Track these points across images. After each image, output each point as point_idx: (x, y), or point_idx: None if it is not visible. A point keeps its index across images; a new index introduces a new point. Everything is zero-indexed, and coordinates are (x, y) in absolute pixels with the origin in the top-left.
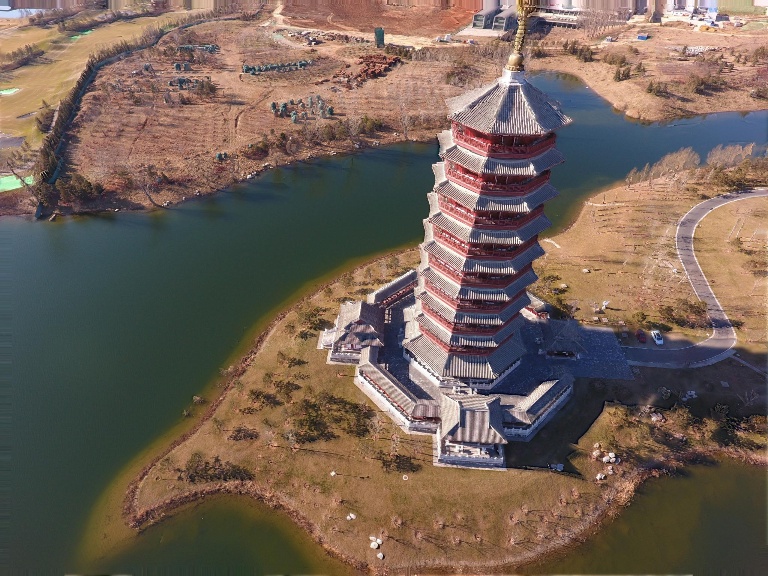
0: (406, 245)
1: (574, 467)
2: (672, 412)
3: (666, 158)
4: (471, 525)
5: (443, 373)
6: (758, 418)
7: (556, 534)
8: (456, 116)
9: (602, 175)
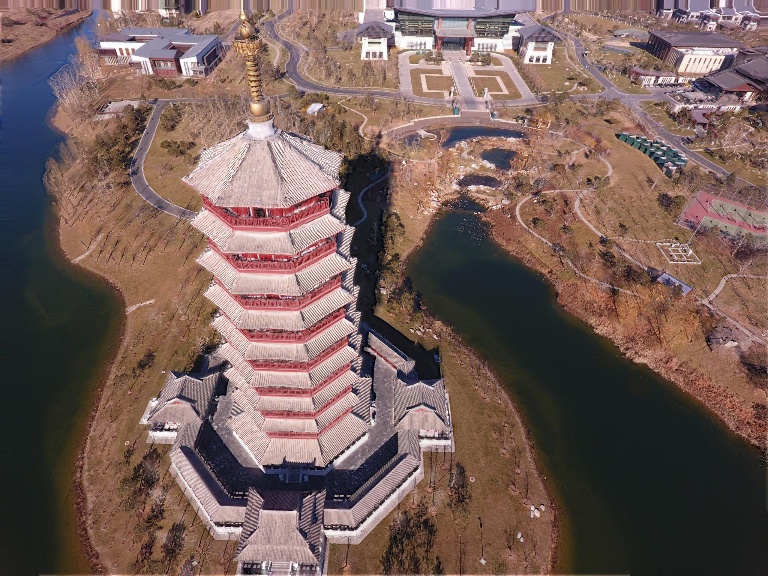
0: (59, 480)
1: (434, 349)
2: (386, 279)
3: (52, 179)
4: (498, 428)
5: (368, 423)
6: (391, 241)
7: (485, 374)
8: (291, 199)
9: (21, 236)
